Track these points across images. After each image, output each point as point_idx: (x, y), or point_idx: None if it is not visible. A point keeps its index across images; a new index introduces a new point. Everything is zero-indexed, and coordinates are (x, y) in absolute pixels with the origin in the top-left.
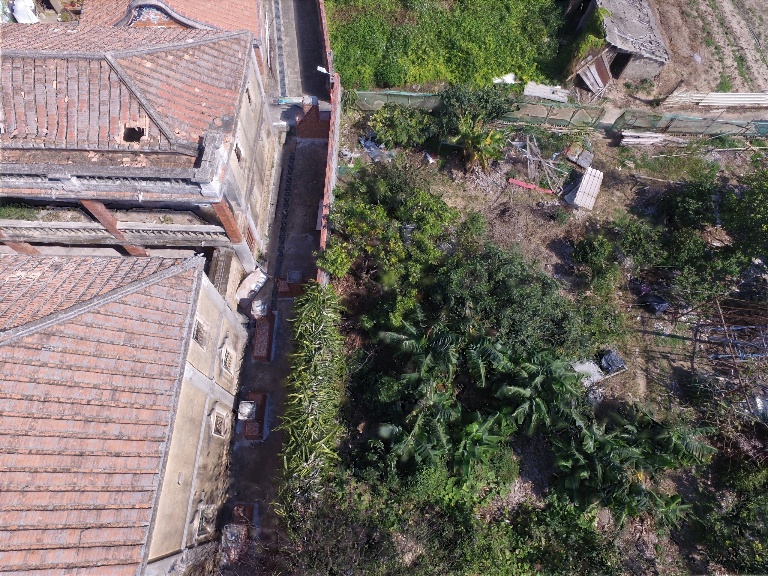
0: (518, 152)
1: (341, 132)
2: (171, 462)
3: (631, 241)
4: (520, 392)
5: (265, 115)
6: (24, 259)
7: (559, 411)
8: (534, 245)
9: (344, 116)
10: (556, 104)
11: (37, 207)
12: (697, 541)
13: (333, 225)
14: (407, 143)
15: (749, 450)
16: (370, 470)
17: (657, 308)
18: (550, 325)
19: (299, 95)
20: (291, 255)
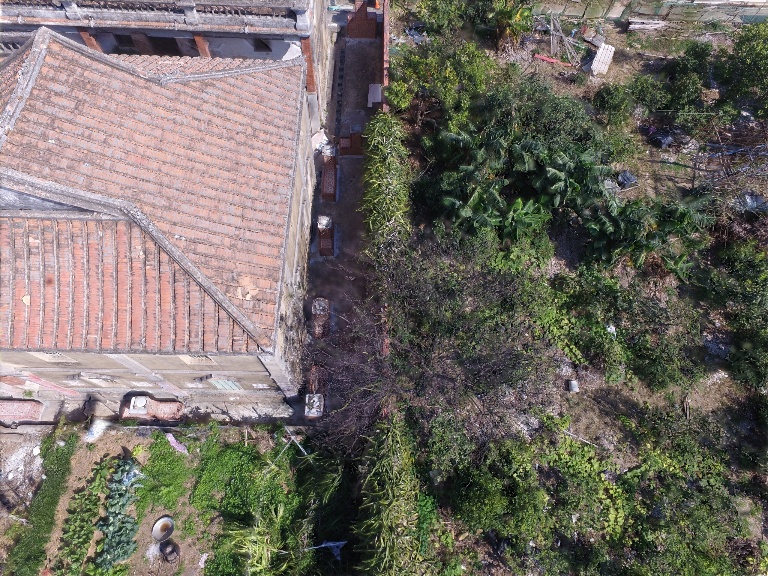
0: (541, 36)
1: None
2: None
3: (640, 89)
4: (557, 175)
5: None
6: (167, 57)
7: (588, 189)
8: None
9: (391, 11)
10: None
11: None
12: (700, 298)
13: (395, 69)
14: None
15: (740, 231)
16: (439, 228)
17: (663, 141)
18: (578, 131)
19: (346, 4)
20: (347, 125)
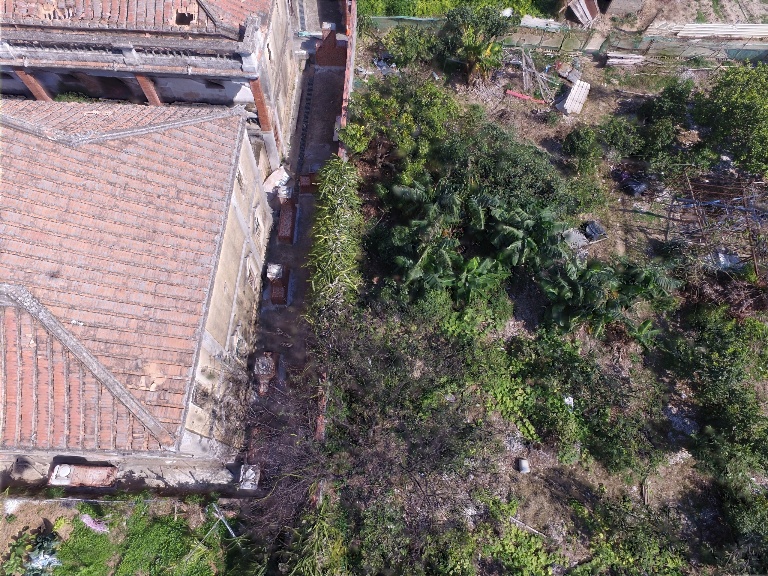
0: (515, 70)
1: (356, 54)
2: (220, 266)
3: (613, 133)
4: (514, 233)
5: (289, 36)
6: (96, 105)
7: (547, 249)
8: (528, 143)
9: (359, 40)
10: (549, 28)
11: (91, 99)
12: (666, 366)
13: (352, 111)
14: (416, 61)
15: (712, 293)
16: (386, 291)
17: (635, 189)
18: (540, 184)
19: (317, 30)
20: (311, 160)
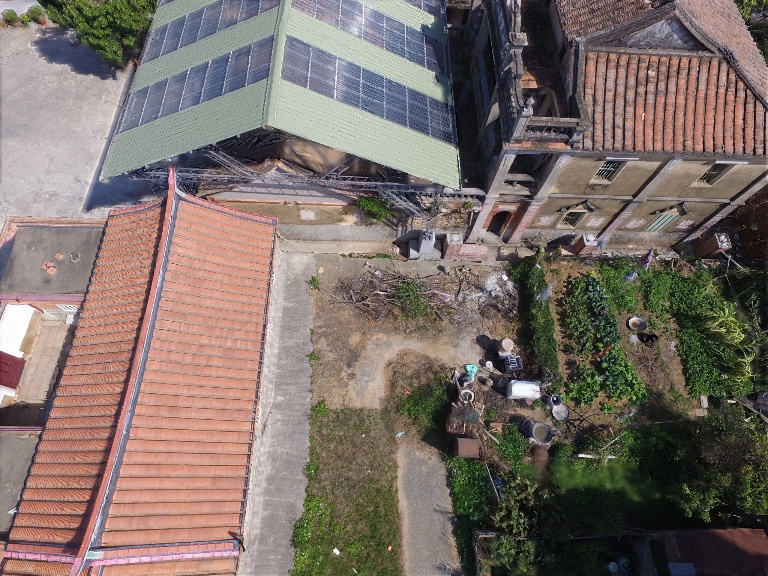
0: None
1: None
2: None
3: None
4: None
5: None
6: None
7: None
8: None
9: None
10: None
11: None
12: None
13: None
14: None
15: None
16: None
17: None
18: None
19: None
20: None
